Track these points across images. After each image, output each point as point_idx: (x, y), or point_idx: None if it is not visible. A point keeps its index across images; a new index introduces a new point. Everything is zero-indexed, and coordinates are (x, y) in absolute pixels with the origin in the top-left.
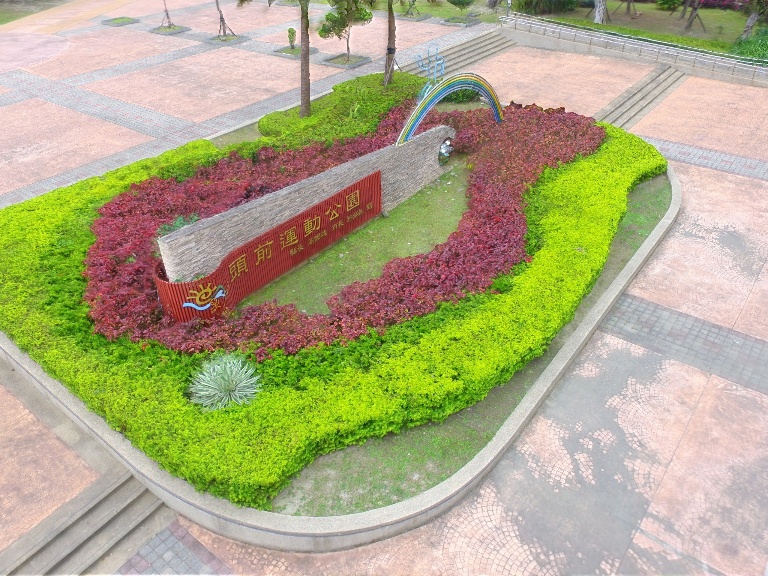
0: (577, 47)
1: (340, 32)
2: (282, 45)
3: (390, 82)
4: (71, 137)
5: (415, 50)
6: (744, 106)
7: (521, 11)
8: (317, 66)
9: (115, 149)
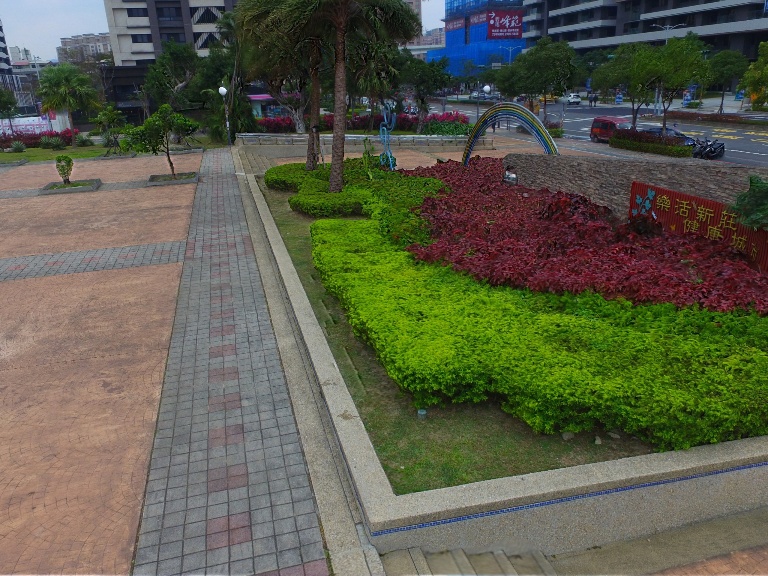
0: (329, 149)
1: (158, 145)
2: (23, 189)
3: (316, 166)
4: (6, 308)
5: (214, 165)
6: (502, 156)
7: (225, 138)
8: (147, 188)
9: (160, 285)
